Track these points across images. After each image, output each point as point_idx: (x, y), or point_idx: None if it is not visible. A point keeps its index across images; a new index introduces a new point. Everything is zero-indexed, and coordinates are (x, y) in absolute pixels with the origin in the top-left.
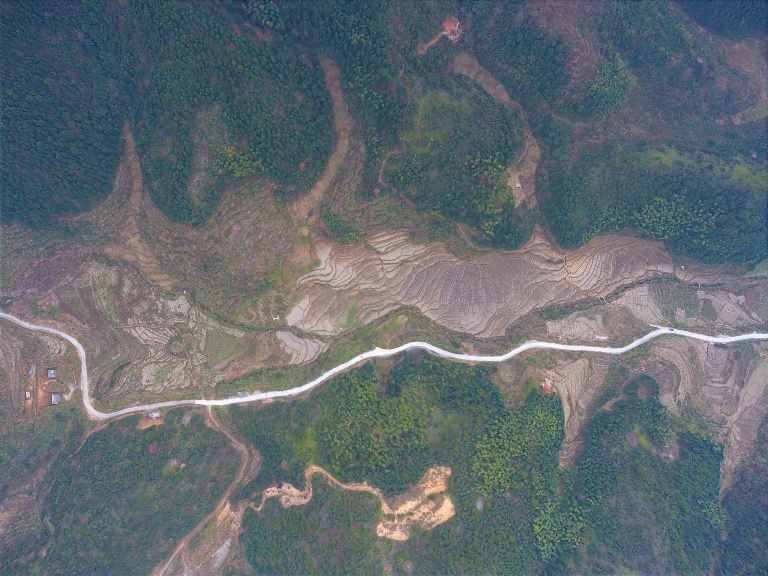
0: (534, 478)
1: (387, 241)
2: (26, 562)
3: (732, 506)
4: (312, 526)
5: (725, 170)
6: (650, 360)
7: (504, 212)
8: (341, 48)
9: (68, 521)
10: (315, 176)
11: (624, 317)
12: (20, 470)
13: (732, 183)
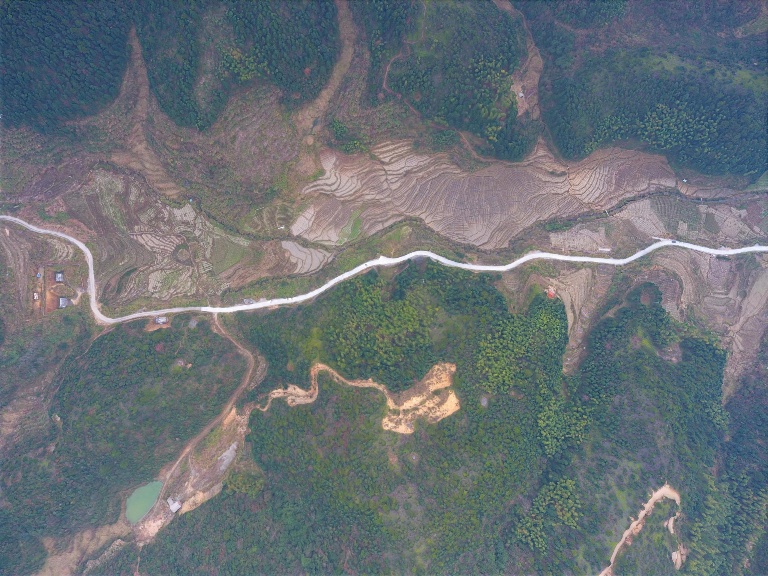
0: (538, 376)
1: (391, 151)
2: (35, 456)
3: (735, 411)
4: (318, 421)
5: (727, 75)
6: (653, 269)
7: (507, 117)
8: None
9: (76, 413)
10: (320, 84)
11: (627, 230)
12: (28, 370)
13: (734, 88)
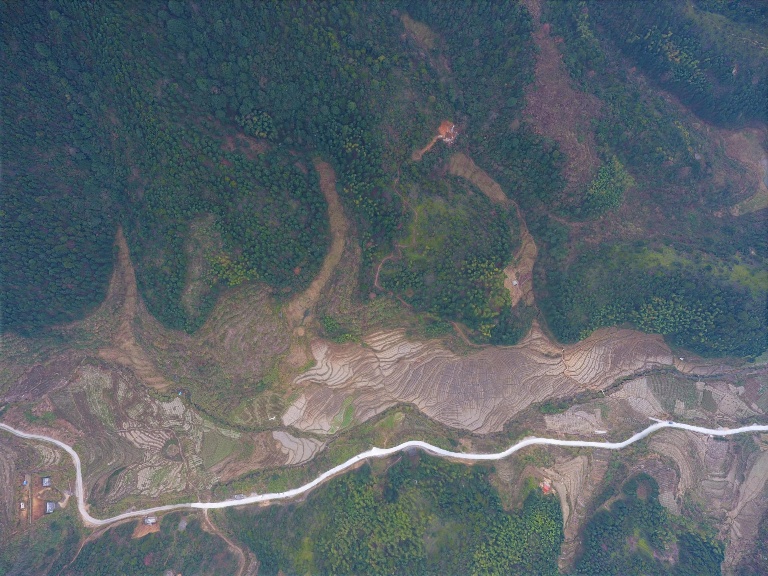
0: None
1: (383, 340)
2: None
3: None
4: None
5: (723, 271)
6: (649, 457)
7: (501, 315)
8: (335, 154)
9: None
10: (310, 277)
11: (623, 410)
12: None
13: (731, 284)
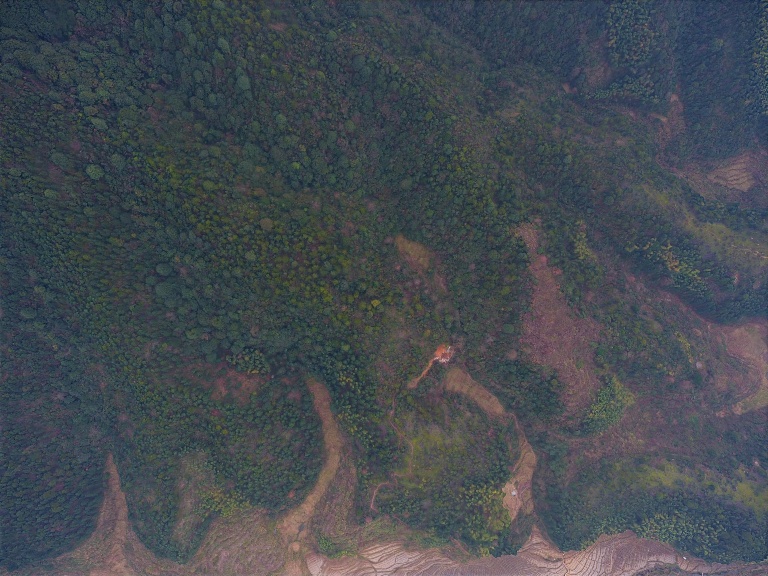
0: None
1: (380, 551)
2: None
3: None
4: None
5: (727, 491)
6: None
7: (500, 536)
8: (329, 381)
9: None
10: (305, 494)
11: None
12: None
13: (734, 504)
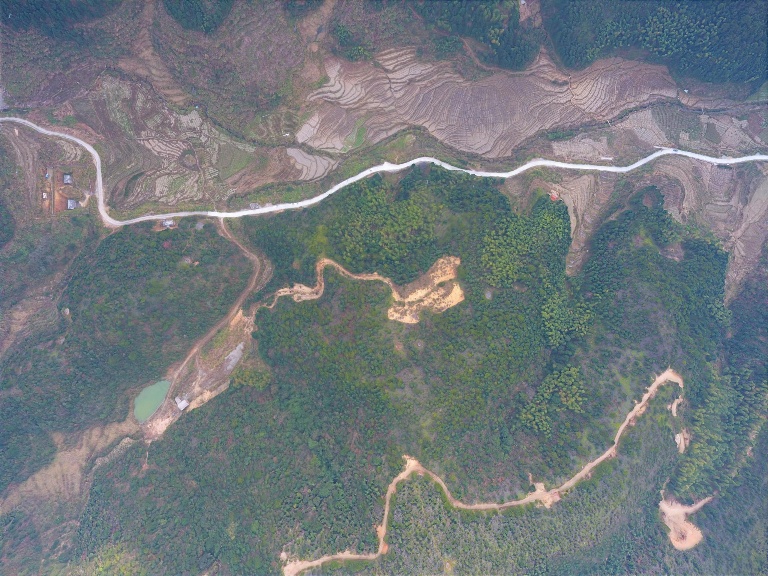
0: (542, 271)
1: (395, 59)
2: (44, 348)
3: (737, 311)
4: (324, 313)
5: None
6: (655, 174)
7: (510, 20)
8: None
9: (86, 303)
10: None
11: (628, 139)
12: (38, 267)
13: None
